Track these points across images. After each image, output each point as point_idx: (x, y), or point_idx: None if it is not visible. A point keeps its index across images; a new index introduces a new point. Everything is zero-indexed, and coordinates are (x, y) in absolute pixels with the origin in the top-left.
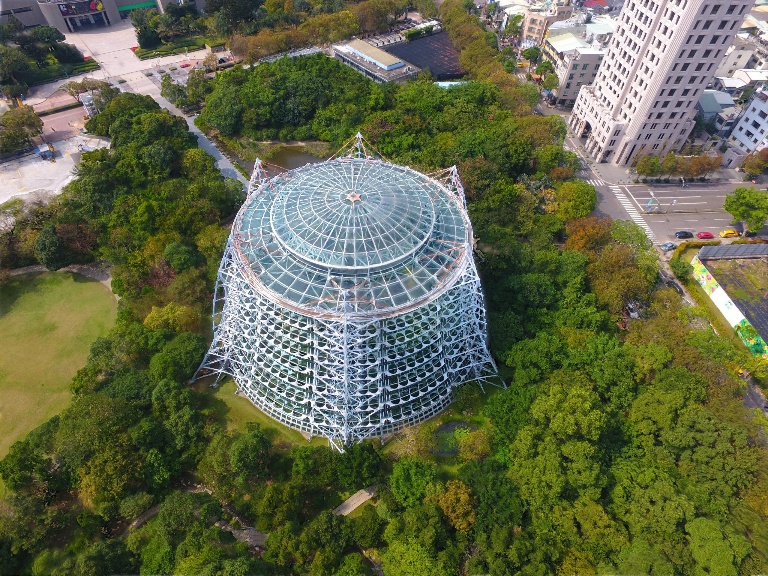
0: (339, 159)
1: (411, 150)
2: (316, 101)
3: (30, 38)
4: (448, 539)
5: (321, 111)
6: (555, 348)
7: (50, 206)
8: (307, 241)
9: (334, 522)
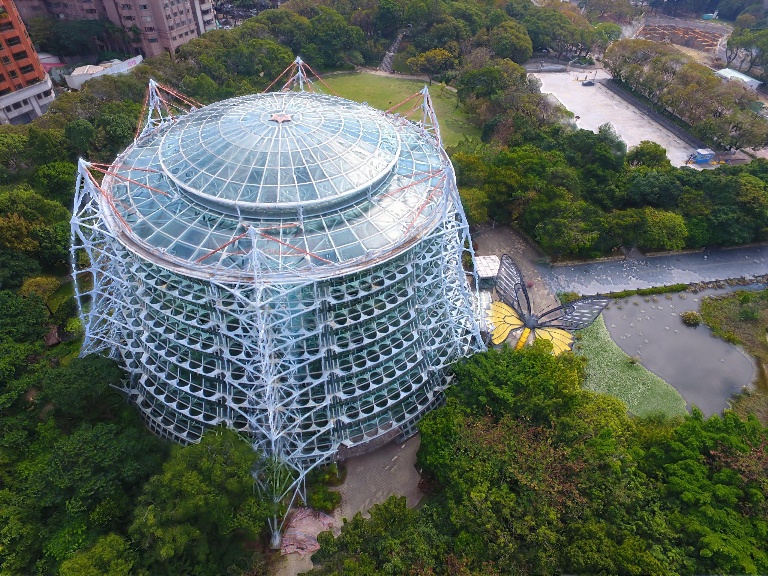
0: None
1: (686, 545)
2: None
3: None
4: (5, 216)
5: None
6: None
7: (535, 108)
8: (258, 96)
9: None
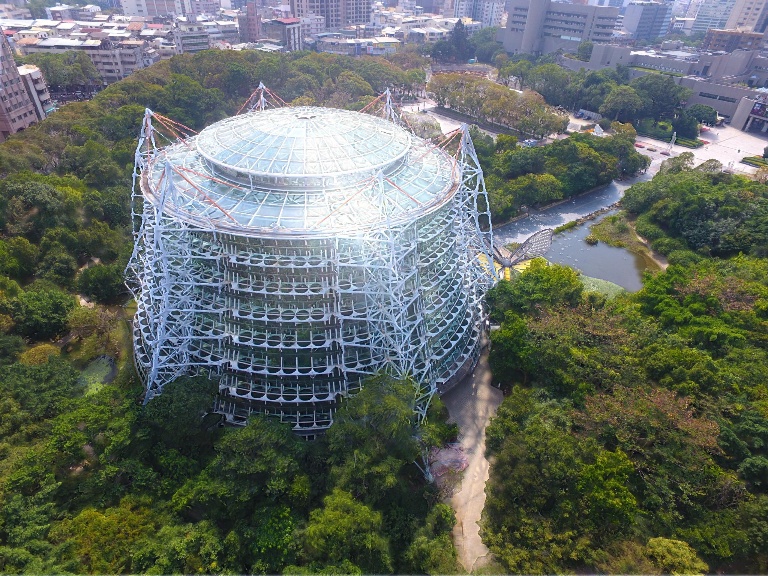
0: (453, 158)
1: (697, 344)
2: (760, 245)
3: (668, 100)
4: None
5: (746, 258)
6: (66, 432)
7: (416, 123)
8: None
9: (57, 263)
